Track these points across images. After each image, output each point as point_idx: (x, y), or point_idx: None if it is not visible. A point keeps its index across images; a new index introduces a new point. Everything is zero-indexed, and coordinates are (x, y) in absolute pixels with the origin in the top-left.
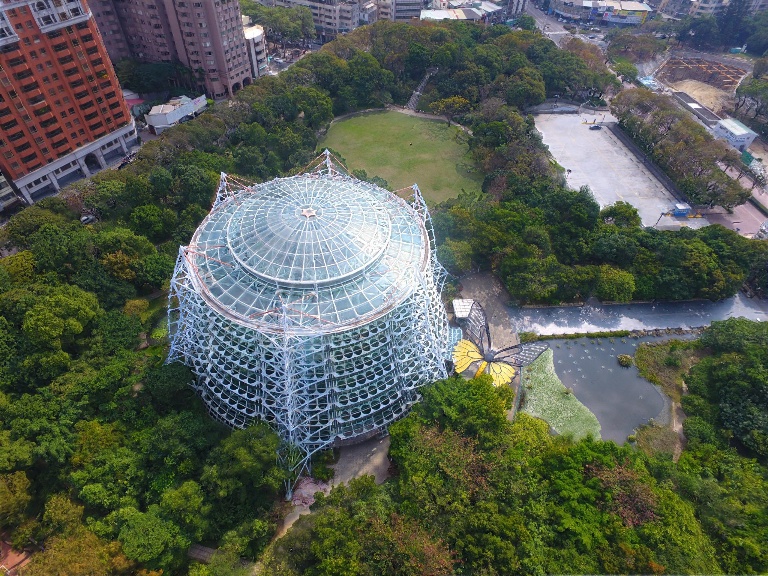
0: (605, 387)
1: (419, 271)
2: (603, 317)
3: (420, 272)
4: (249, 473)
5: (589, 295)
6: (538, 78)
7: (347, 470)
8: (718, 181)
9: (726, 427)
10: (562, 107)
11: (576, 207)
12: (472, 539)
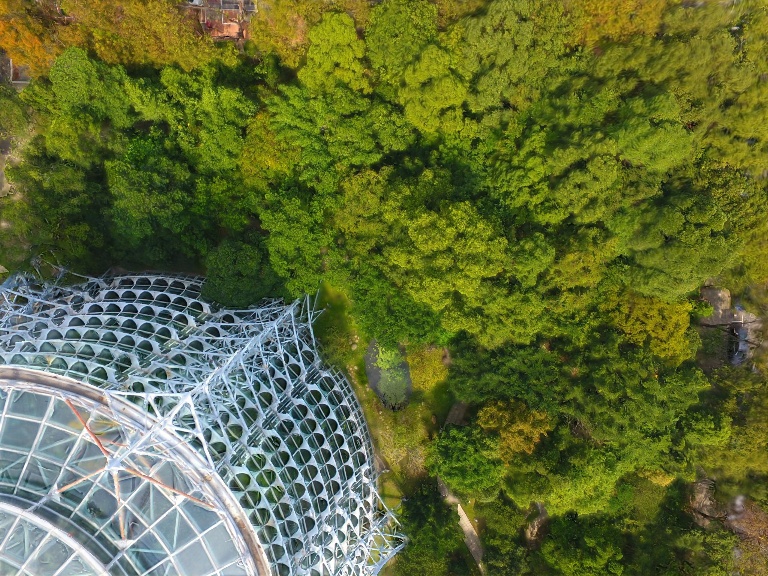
0: None
1: None
2: None
3: None
4: None
5: None
6: None
7: None
8: None
9: None
10: None
11: None
12: None
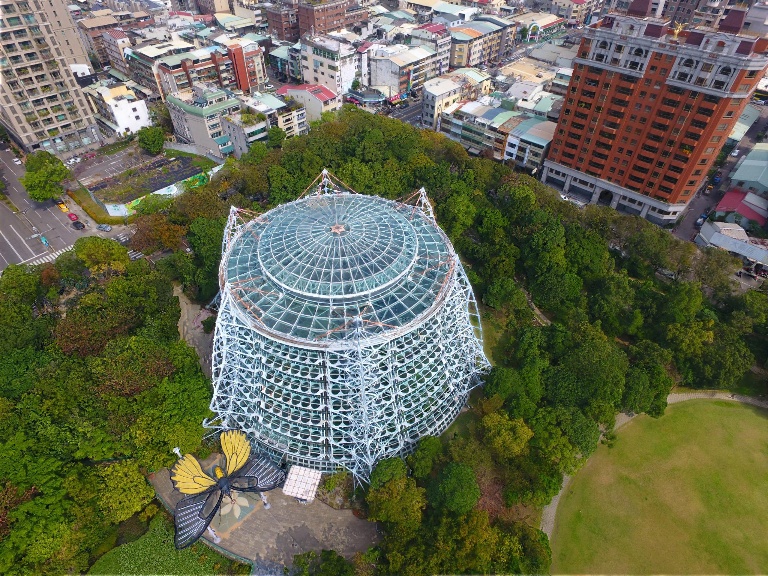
0: None
1: None
2: None
3: (238, 309)
4: None
5: None
6: None
7: (204, 341)
8: None
9: None
10: None
11: None
12: (72, 364)
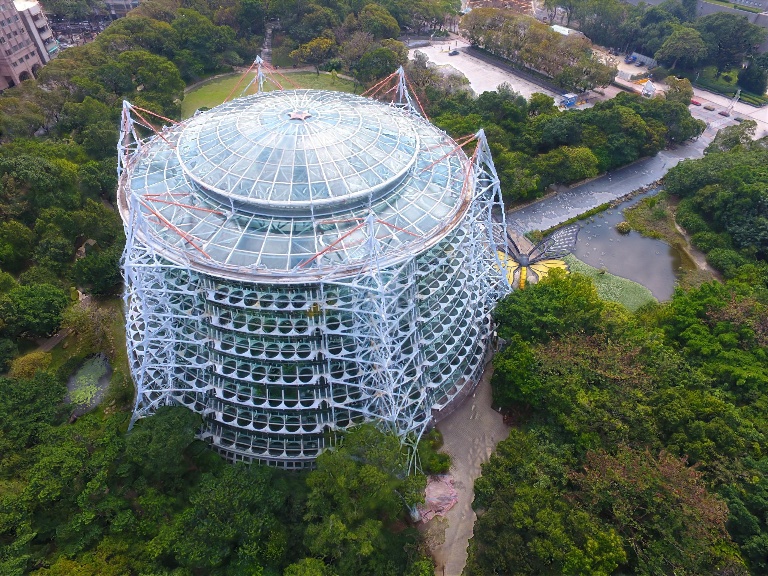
0: (626, 256)
1: (484, 145)
2: (579, 199)
3: None
4: (381, 502)
5: (562, 180)
6: (386, 13)
7: (460, 446)
8: (589, 66)
9: (745, 246)
10: (413, 42)
11: (506, 104)
12: (684, 435)
